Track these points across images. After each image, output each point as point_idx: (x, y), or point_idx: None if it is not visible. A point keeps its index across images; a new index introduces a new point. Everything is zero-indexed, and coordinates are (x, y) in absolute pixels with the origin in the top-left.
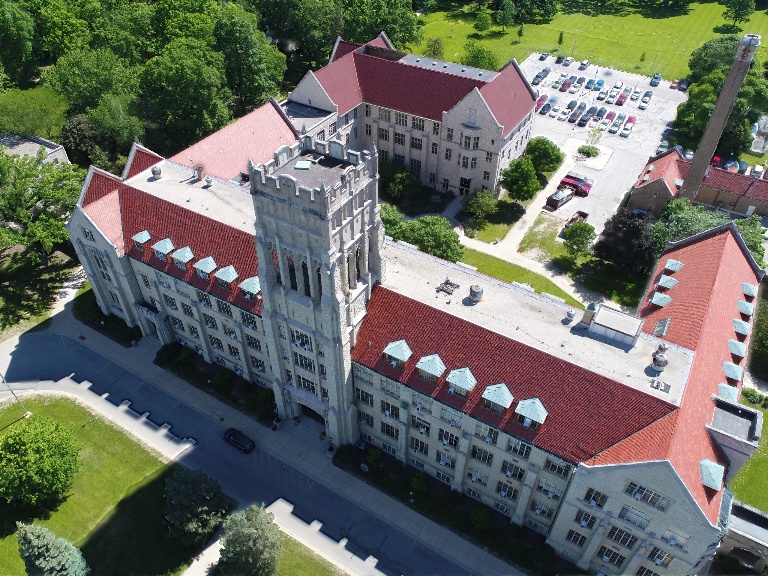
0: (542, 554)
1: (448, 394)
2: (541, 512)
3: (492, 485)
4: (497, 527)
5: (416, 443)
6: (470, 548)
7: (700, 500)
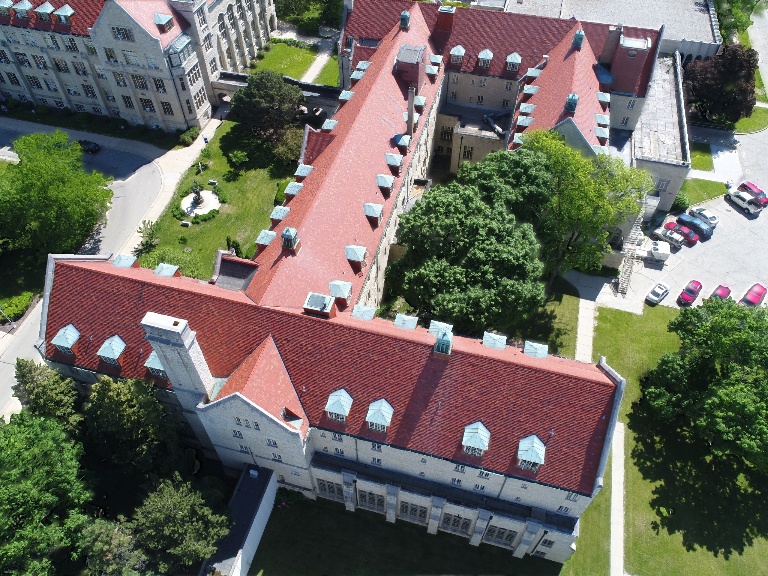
0: (117, 122)
1: (18, 19)
2: (113, 99)
3: (81, 91)
4: (95, 121)
5: (32, 81)
6: (74, 132)
7: (151, 29)
